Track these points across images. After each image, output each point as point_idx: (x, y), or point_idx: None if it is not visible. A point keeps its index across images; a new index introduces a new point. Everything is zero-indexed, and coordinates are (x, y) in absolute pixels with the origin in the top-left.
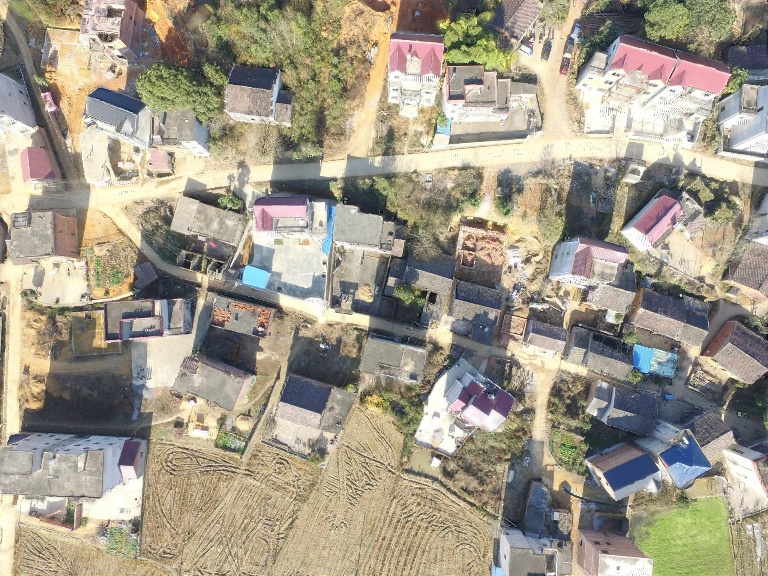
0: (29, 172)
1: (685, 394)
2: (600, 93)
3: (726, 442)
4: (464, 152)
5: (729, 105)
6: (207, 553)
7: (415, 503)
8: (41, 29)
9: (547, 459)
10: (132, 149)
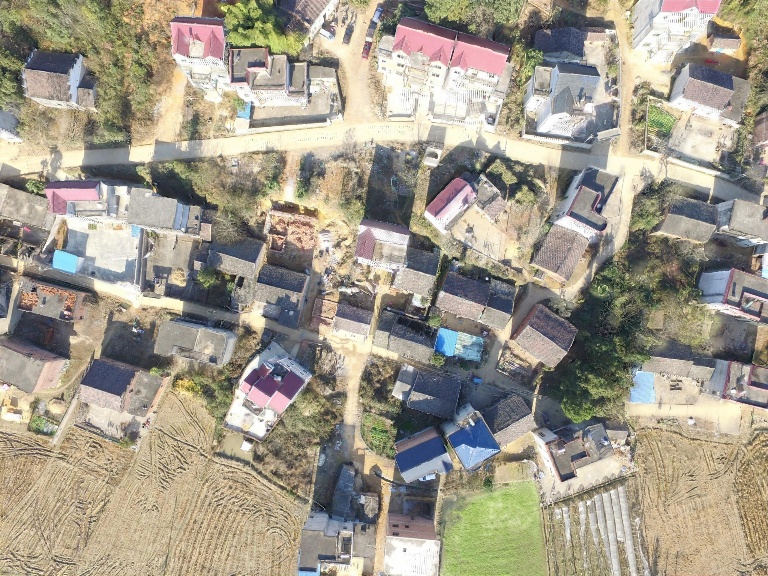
0: None
1: (496, 378)
2: (399, 76)
3: (528, 425)
4: (268, 136)
5: (529, 88)
6: (20, 536)
7: (226, 487)
8: None
9: (358, 443)
10: None
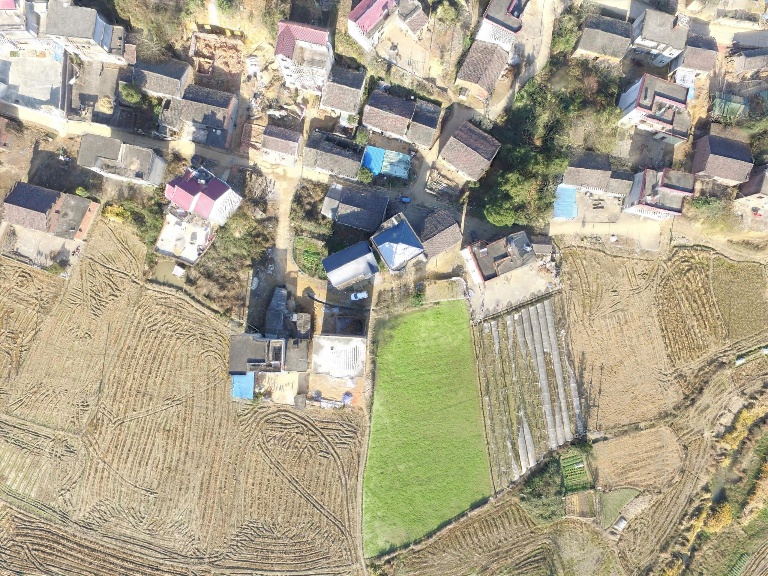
0: None
1: (425, 199)
2: None
3: (454, 236)
4: None
5: None
6: None
7: (159, 312)
8: None
9: (290, 266)
10: None
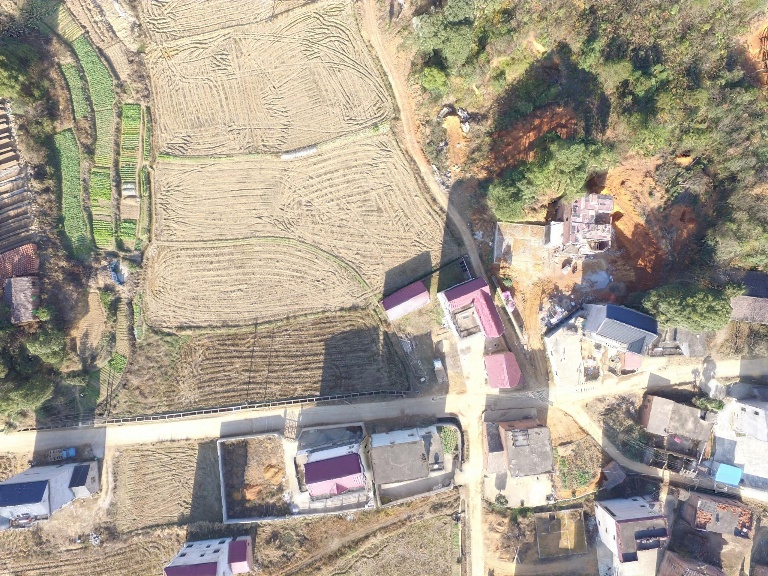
0: (507, 380)
1: None
2: None
3: None
4: None
5: None
6: None
7: None
8: (489, 222)
9: None
10: (593, 346)
